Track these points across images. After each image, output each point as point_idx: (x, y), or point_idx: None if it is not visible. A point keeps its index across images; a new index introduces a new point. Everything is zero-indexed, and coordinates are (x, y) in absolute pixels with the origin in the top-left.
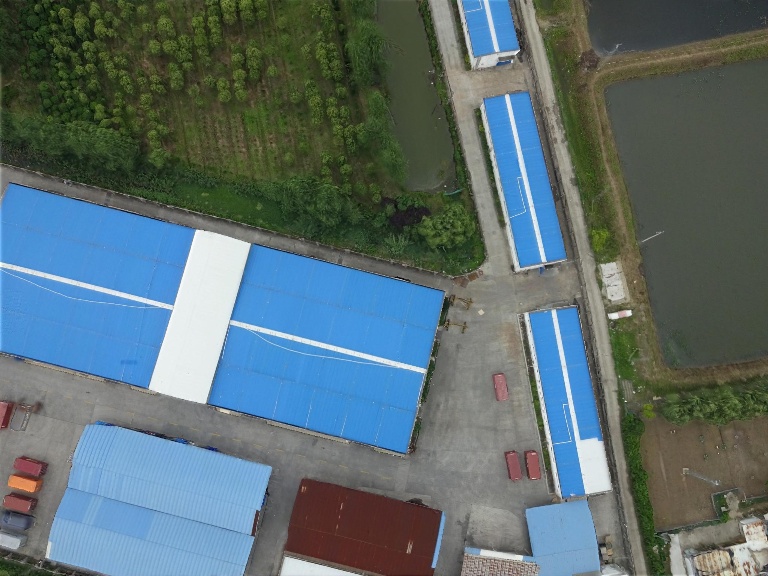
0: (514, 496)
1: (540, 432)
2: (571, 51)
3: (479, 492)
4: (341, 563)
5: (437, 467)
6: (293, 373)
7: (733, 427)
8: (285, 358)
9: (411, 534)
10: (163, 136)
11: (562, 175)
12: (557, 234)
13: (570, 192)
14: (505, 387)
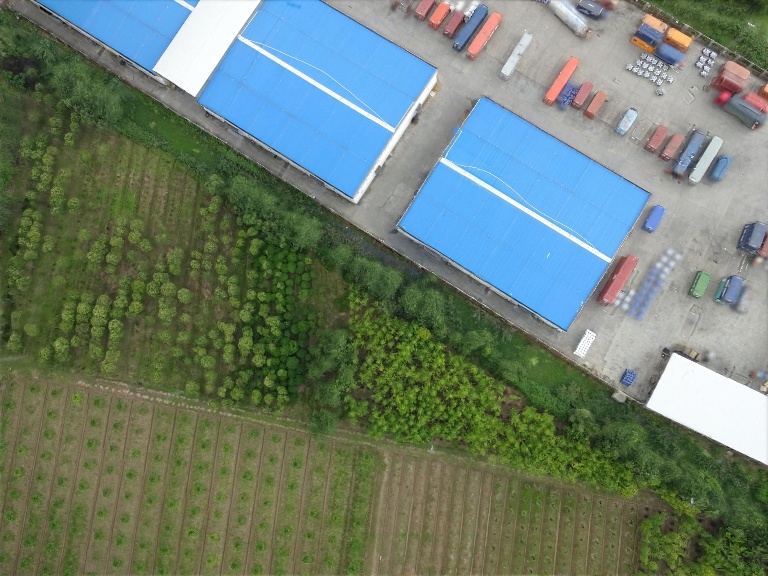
0: None
1: None
2: None
3: None
4: None
5: None
6: None
7: None
8: None
9: None
10: None
11: None
12: None
13: None
14: None
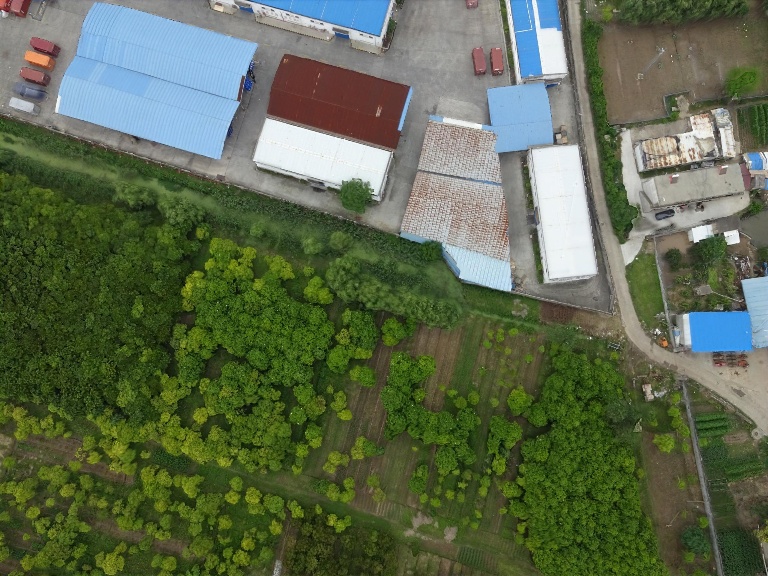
0: (479, 91)
1: (506, 36)
2: None
3: (447, 87)
4: (317, 127)
5: (409, 64)
6: None
7: (688, 40)
8: None
9: (381, 100)
10: None
11: None
12: None
13: None
14: None
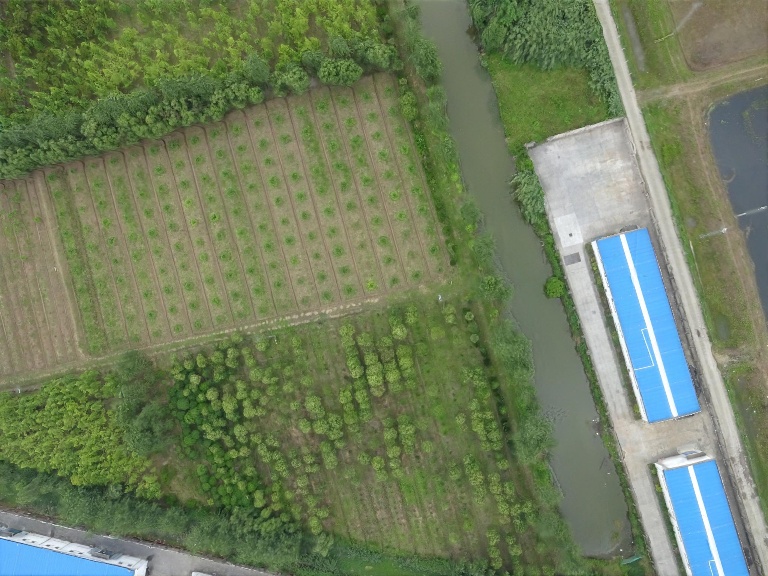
0: None
1: None
2: (757, 390)
3: None
4: None
5: None
6: None
7: None
8: None
9: None
10: (323, 518)
11: (755, 536)
12: None
13: (765, 555)
14: None
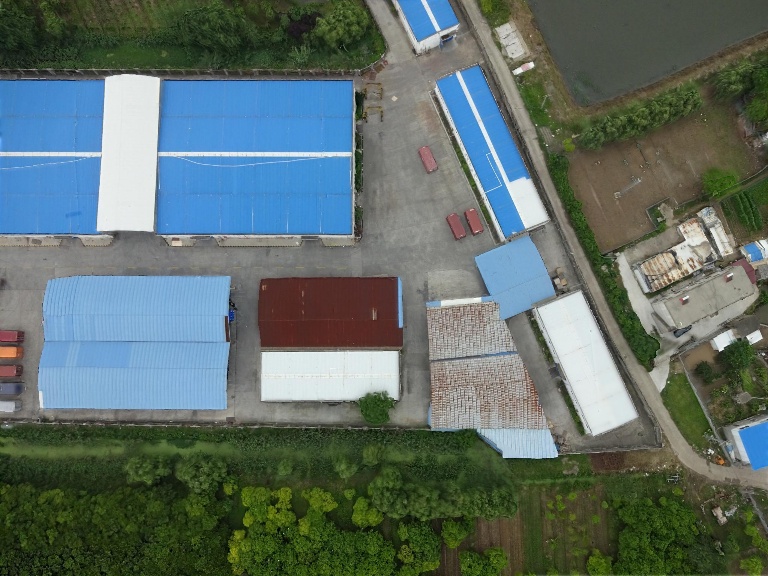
0: (464, 255)
1: (474, 192)
2: None
3: (431, 260)
4: (315, 346)
5: (387, 247)
6: (229, 187)
7: (652, 145)
8: (218, 175)
9: (373, 302)
10: (55, 7)
11: None
12: (445, 4)
13: None
14: (431, 157)
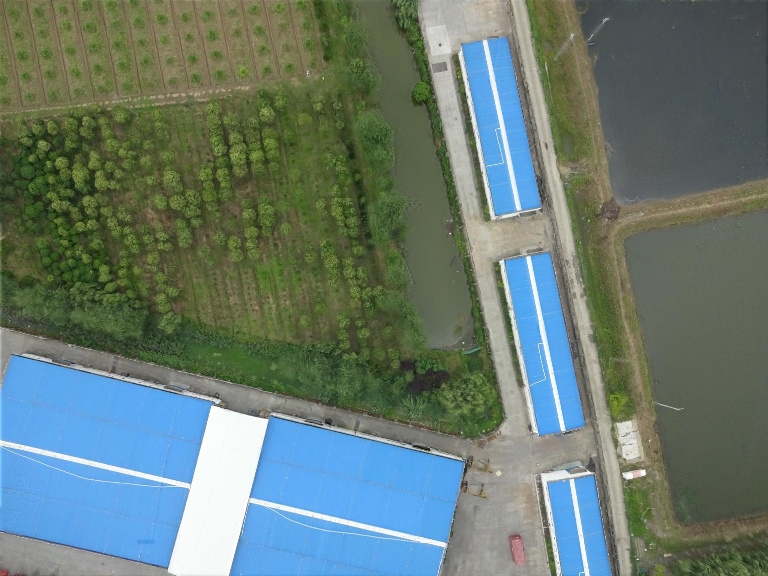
0: None
1: None
2: (592, 200)
3: None
4: None
5: None
6: (313, 548)
7: None
8: (305, 534)
9: None
10: (172, 297)
11: (580, 331)
12: (576, 401)
13: (588, 349)
14: (522, 552)
